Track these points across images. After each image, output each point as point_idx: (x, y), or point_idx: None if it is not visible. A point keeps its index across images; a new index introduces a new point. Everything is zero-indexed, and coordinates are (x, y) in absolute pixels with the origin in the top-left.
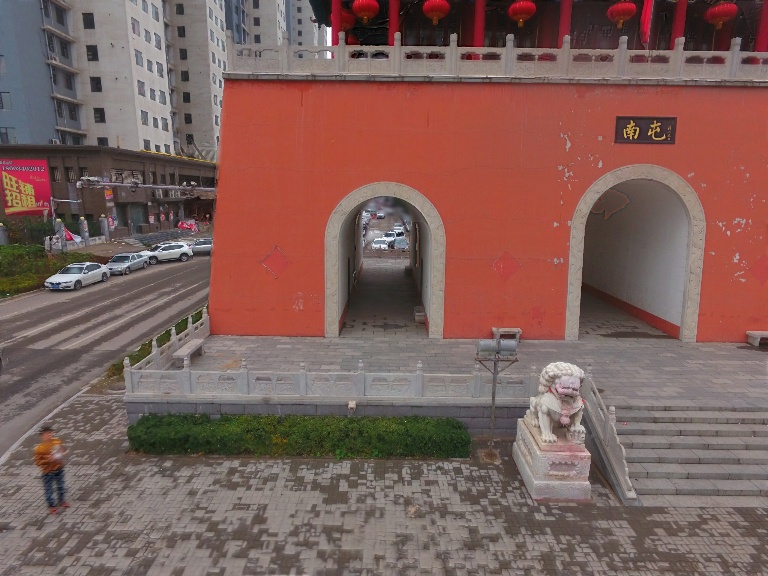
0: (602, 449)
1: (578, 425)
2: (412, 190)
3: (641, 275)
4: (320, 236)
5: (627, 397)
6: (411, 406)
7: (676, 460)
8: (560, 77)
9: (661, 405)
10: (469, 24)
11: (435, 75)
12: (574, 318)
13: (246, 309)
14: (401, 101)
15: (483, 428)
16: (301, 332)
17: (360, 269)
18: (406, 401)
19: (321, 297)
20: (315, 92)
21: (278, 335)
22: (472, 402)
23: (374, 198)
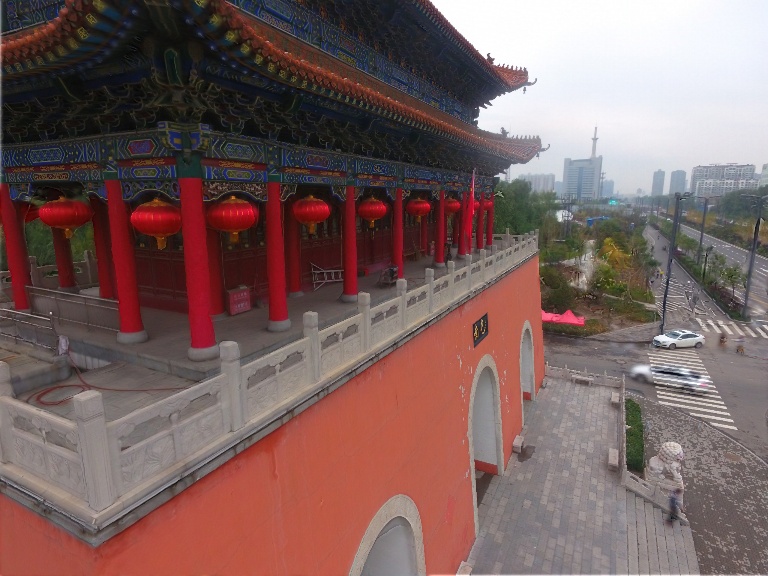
0: None
1: None
2: (397, 498)
3: None
4: None
5: None
6: None
7: None
8: (455, 303)
9: None
10: (291, 206)
11: (399, 339)
12: (476, 514)
13: None
14: (377, 388)
15: None
16: None
17: None
18: None
19: None
20: (289, 438)
21: None
22: None
23: None
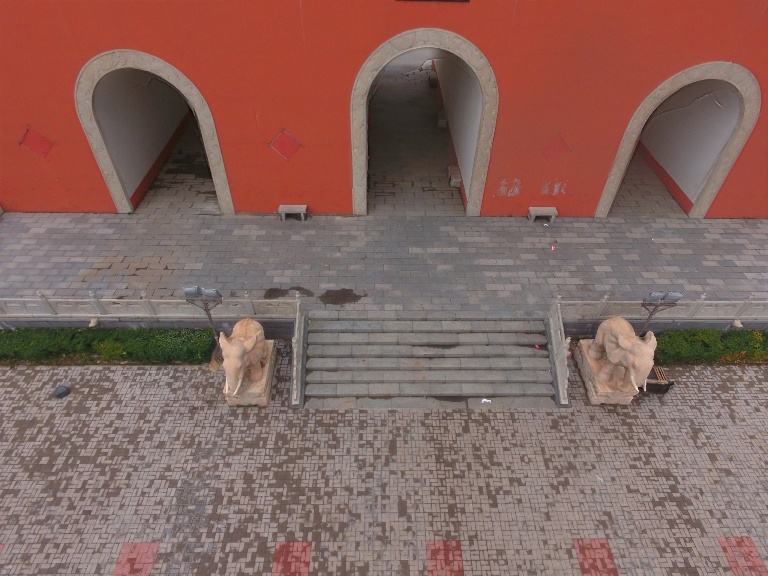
0: None
1: None
2: None
3: None
4: None
5: None
6: None
7: None
8: None
9: None
10: None
11: None
12: None
13: None
14: None
15: None
16: None
17: (657, 163)
18: None
19: None
20: None
21: None
22: None
23: None
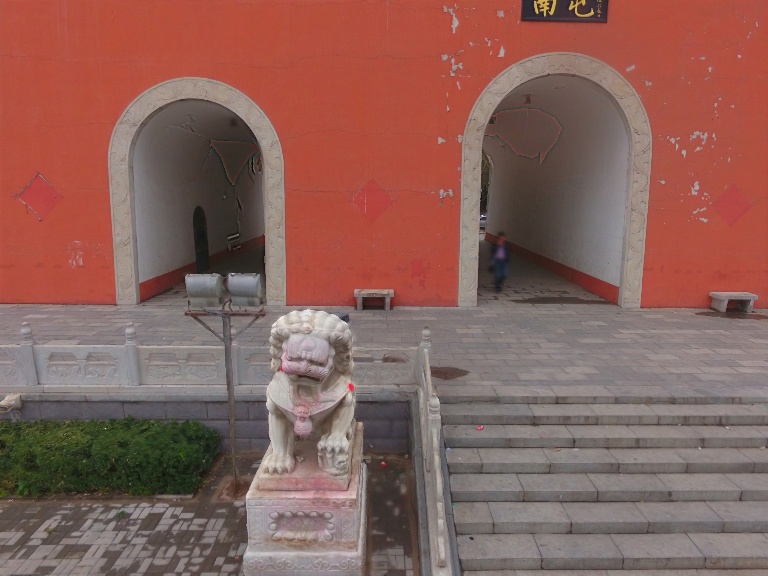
0: (421, 477)
1: (334, 436)
2: (231, 90)
3: (577, 225)
4: (102, 158)
5: (500, 382)
6: (119, 402)
7: (555, 496)
8: None
9: (550, 395)
10: None
11: None
12: (470, 275)
13: (0, 265)
14: None
15: (251, 437)
16: (83, 298)
17: (261, 237)
18: (110, 393)
19: (108, 247)
20: None
21: (49, 303)
22: (225, 393)
23: (176, 101)
